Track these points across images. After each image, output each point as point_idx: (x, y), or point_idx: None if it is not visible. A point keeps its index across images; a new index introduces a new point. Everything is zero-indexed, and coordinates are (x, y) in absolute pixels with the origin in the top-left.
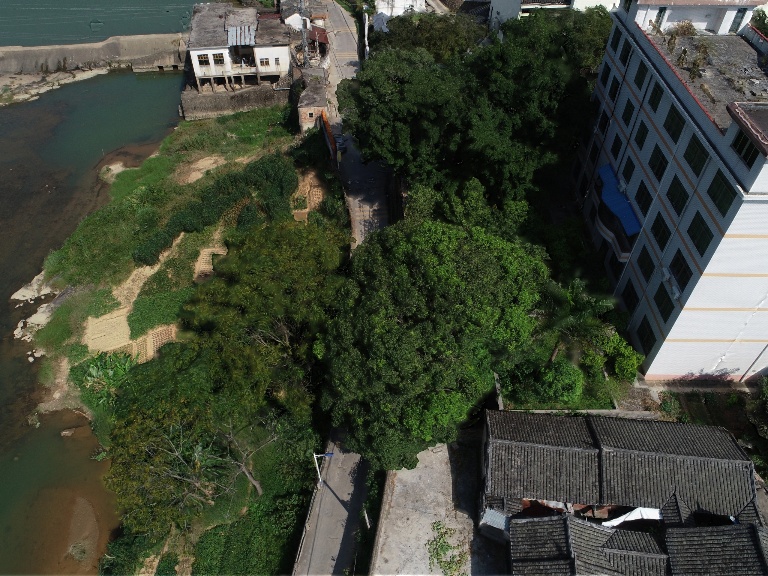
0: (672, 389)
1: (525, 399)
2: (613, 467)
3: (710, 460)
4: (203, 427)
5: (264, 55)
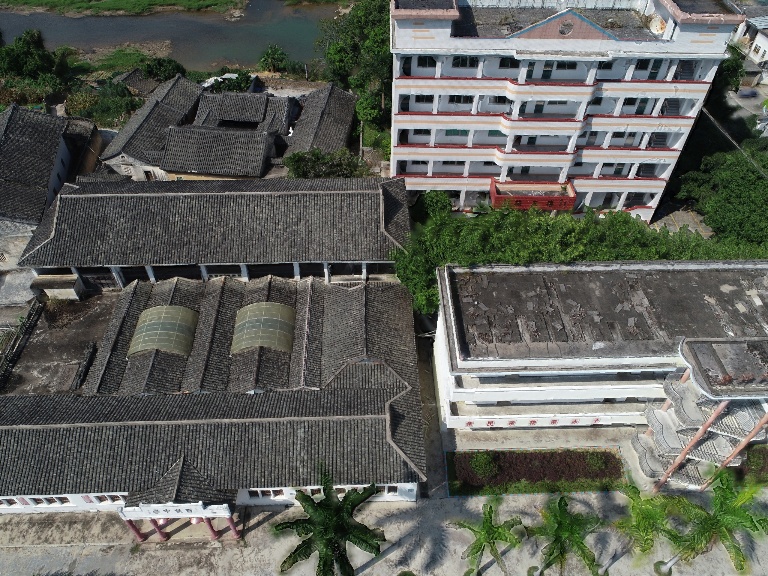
0: None
1: None
2: None
3: None
4: None
5: (760, 42)
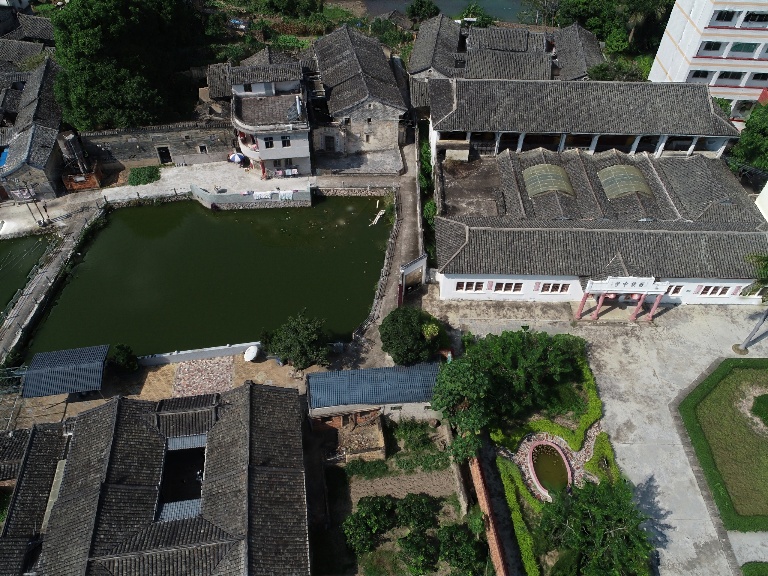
0: None
1: None
2: None
3: None
4: None
5: None
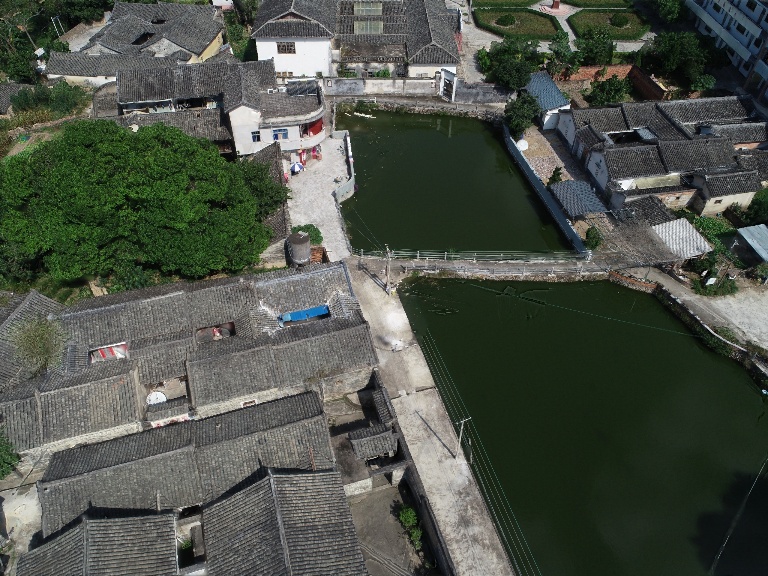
0: (224, 11)
1: (145, 1)
2: (161, 8)
3: (199, 6)
4: (7, 8)
5: None
